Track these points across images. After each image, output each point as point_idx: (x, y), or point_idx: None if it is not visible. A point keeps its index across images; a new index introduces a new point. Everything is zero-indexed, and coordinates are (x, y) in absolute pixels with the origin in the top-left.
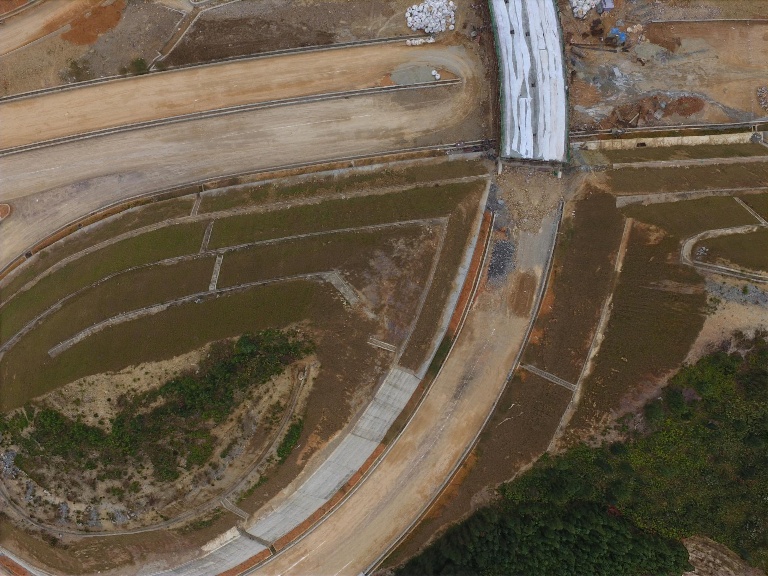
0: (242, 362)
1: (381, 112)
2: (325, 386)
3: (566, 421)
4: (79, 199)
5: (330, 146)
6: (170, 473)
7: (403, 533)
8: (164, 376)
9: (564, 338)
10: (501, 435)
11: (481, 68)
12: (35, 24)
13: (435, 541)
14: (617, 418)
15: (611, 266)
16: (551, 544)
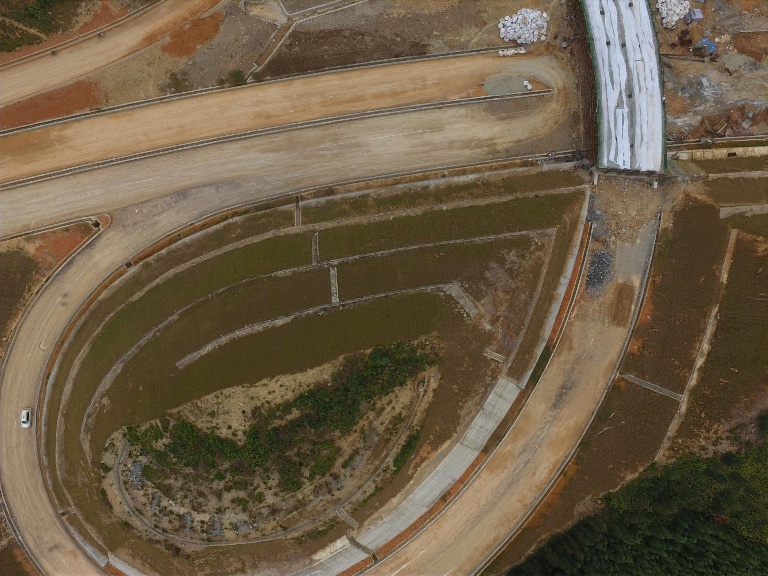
0: (374, 374)
1: (473, 122)
2: (443, 397)
3: (673, 431)
4: (178, 209)
5: (423, 156)
6: (295, 484)
7: (504, 541)
8: (298, 388)
9: (666, 348)
10: (602, 444)
11: (572, 78)
12: (135, 36)
13: (537, 549)
14: (729, 428)
15: (717, 277)
16: (656, 553)
